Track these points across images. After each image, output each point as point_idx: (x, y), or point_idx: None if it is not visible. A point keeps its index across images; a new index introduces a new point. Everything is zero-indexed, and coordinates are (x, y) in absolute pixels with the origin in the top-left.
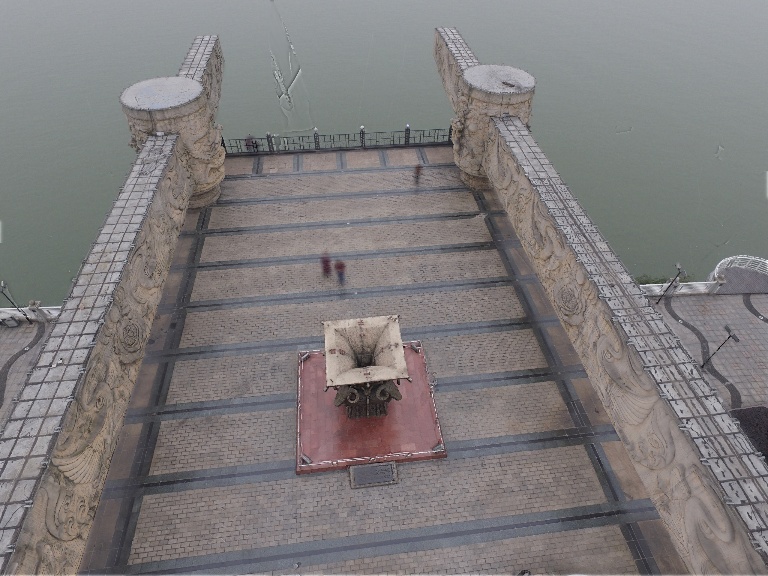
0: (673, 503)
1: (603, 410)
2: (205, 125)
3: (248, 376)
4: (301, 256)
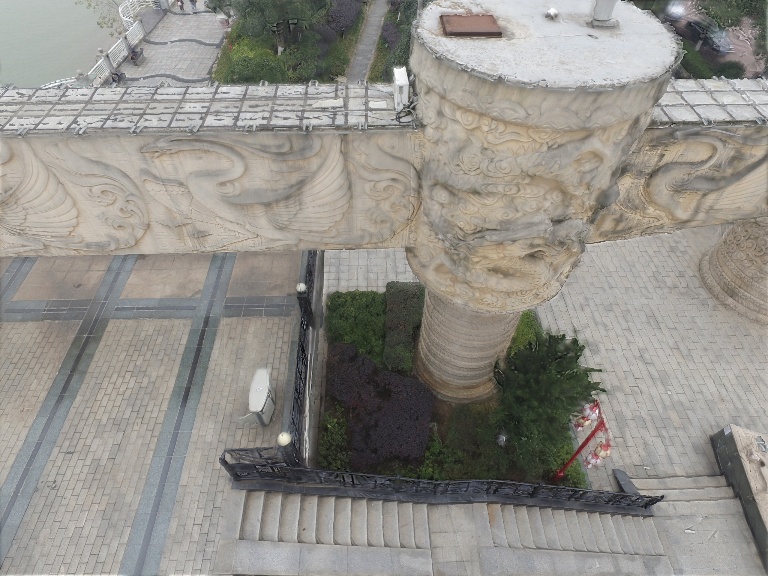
0: (196, 221)
1: (81, 278)
2: None
3: None
4: None
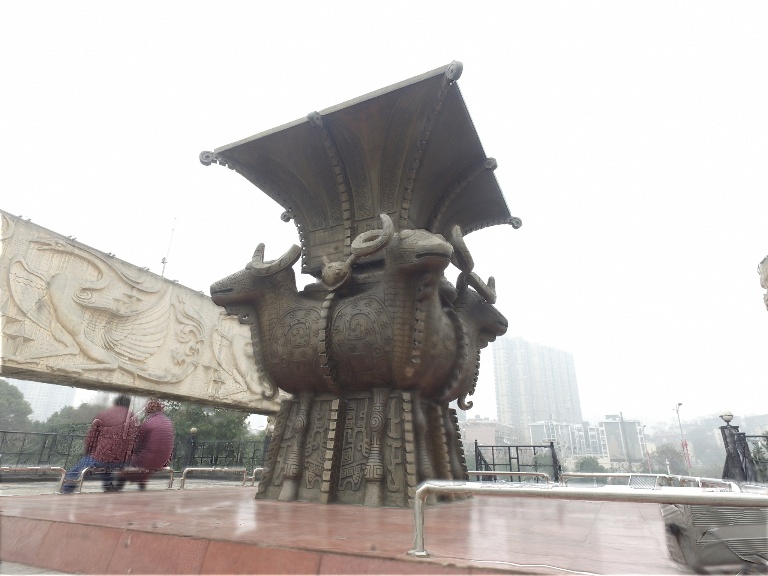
0: None
1: None
2: None
3: None
4: None
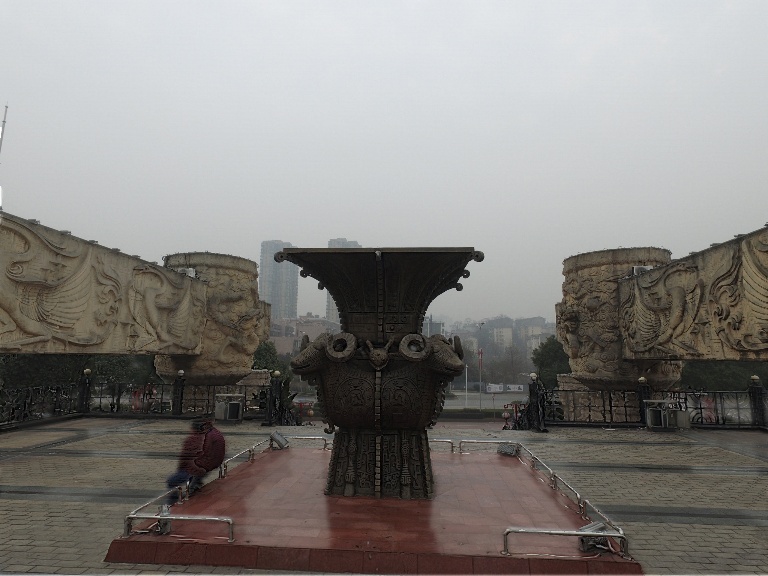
0: None
1: None
2: None
3: None
4: None
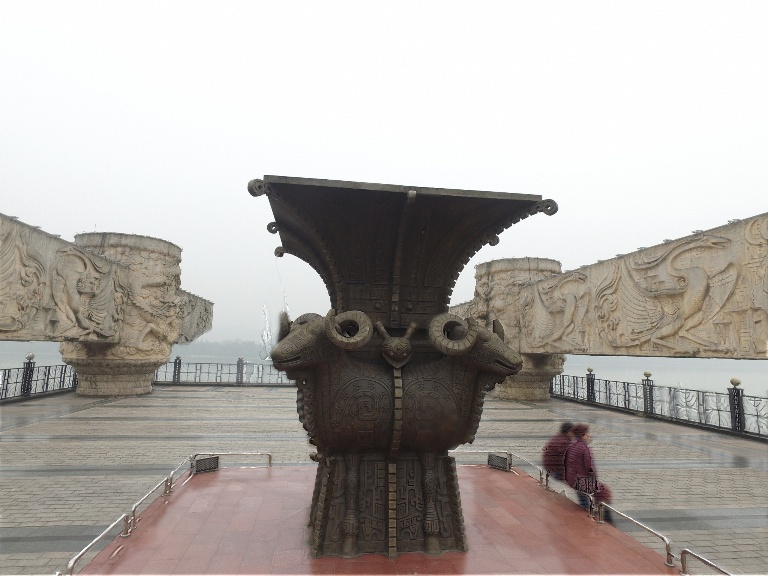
0: None
1: None
2: (166, 274)
3: (7, 499)
4: (250, 417)
